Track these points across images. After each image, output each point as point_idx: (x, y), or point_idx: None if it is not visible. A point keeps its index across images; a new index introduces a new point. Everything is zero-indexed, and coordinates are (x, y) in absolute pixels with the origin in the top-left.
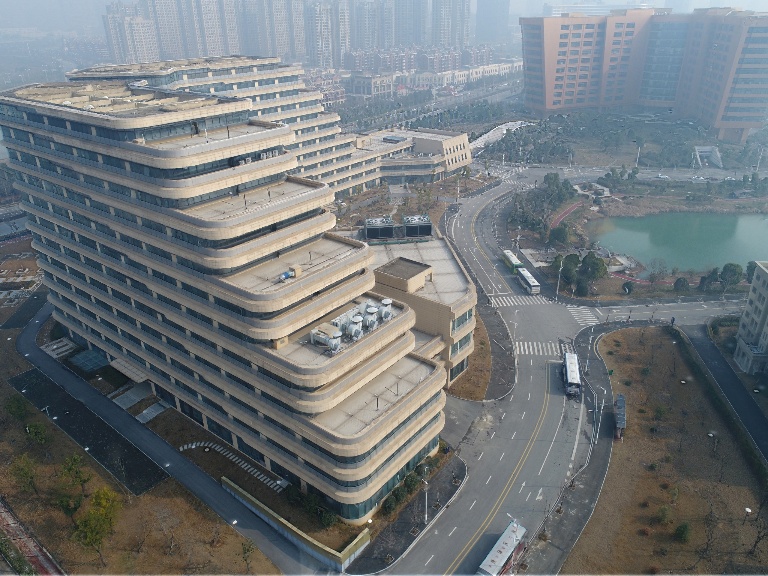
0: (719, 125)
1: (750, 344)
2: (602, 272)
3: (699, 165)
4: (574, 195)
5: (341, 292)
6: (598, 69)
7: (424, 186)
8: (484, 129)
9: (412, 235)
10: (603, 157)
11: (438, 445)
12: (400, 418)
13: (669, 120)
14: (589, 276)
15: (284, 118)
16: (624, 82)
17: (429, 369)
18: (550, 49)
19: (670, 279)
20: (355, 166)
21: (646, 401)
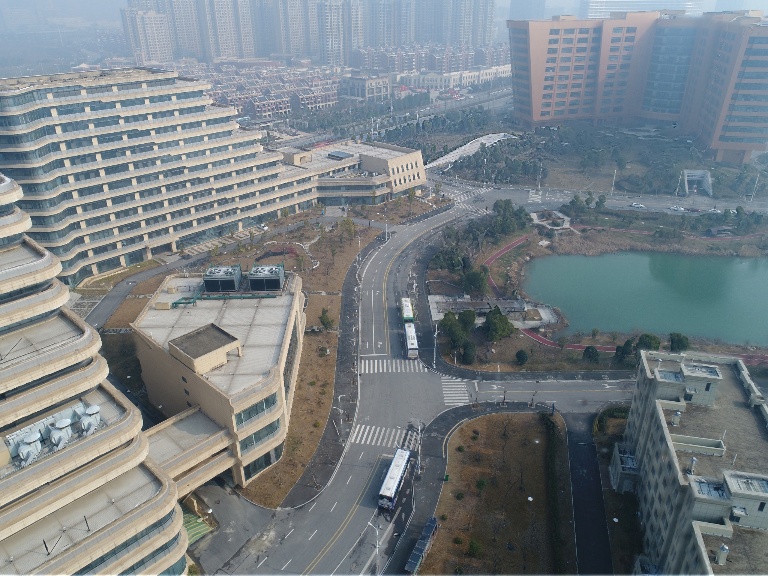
0: (716, 146)
1: (628, 452)
2: (506, 331)
3: (685, 192)
4: (526, 226)
5: (38, 395)
6: (594, 77)
7: (362, 209)
8: (462, 141)
9: (258, 289)
10: (579, 179)
11: (183, 575)
12: (70, 568)
13: (668, 136)
14: None
15: (185, 137)
16: (624, 92)
17: (156, 490)
18: (537, 55)
19: (588, 343)
20: (284, 186)
21: (468, 527)
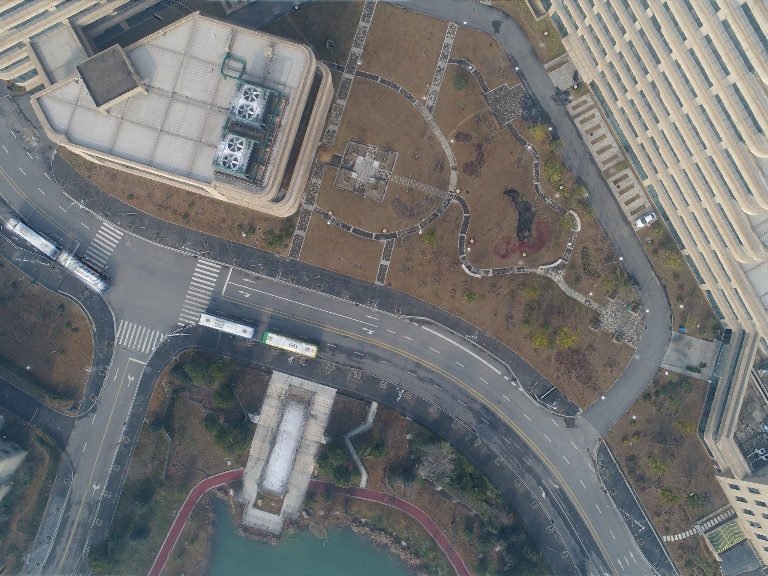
0: None
1: None
2: None
3: None
4: None
5: None
6: None
7: None
8: None
9: None
10: None
11: None
12: None
13: None
14: (231, 427)
15: (694, 47)
16: None
17: None
18: None
19: (189, 527)
20: None
21: None
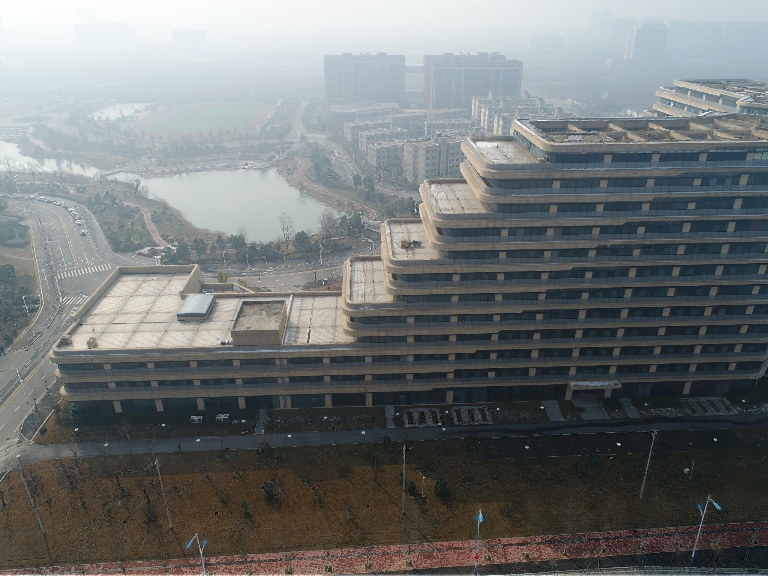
0: None
1: None
2: None
3: None
4: None
5: None
6: None
7: None
8: None
9: None
10: (1, 261)
11: None
12: None
13: None
14: None
15: None
16: None
17: None
18: None
19: None
20: None
21: None
